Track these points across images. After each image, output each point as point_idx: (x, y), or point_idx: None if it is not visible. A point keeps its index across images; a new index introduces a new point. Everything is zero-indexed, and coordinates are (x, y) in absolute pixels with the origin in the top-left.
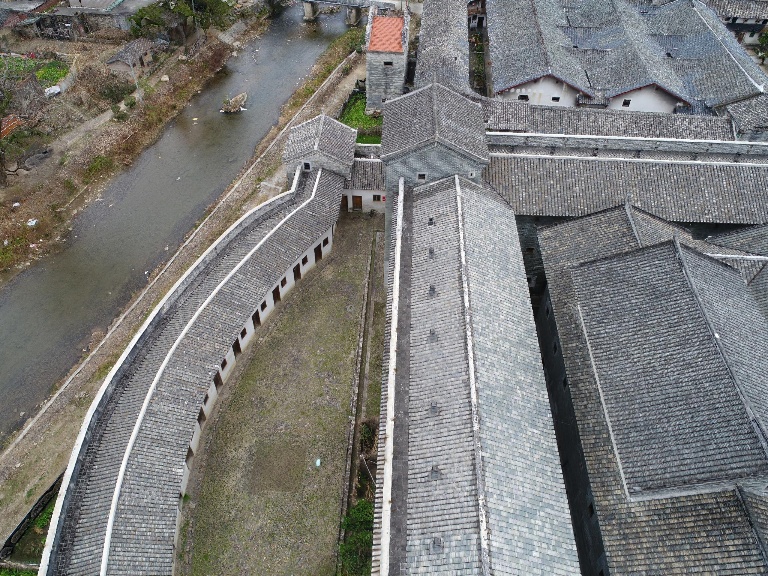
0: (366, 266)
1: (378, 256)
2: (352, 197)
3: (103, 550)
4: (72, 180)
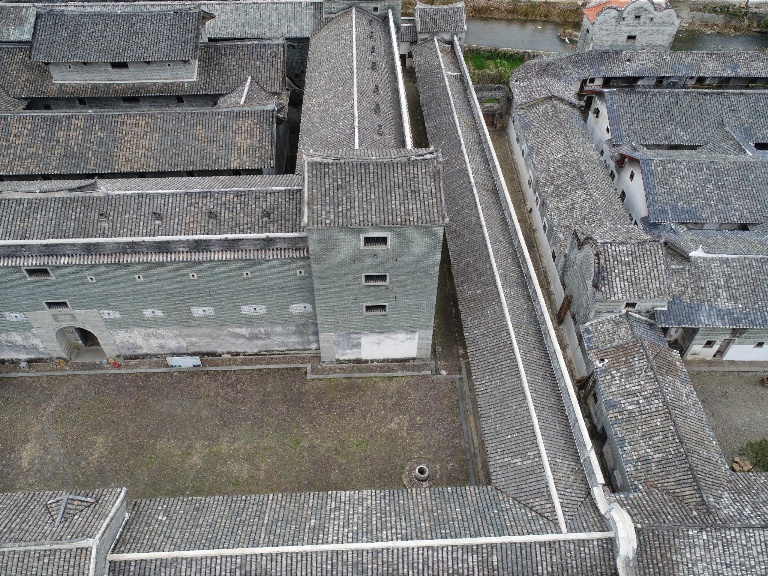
0: None
1: None
2: None
3: None
4: (437, 2)
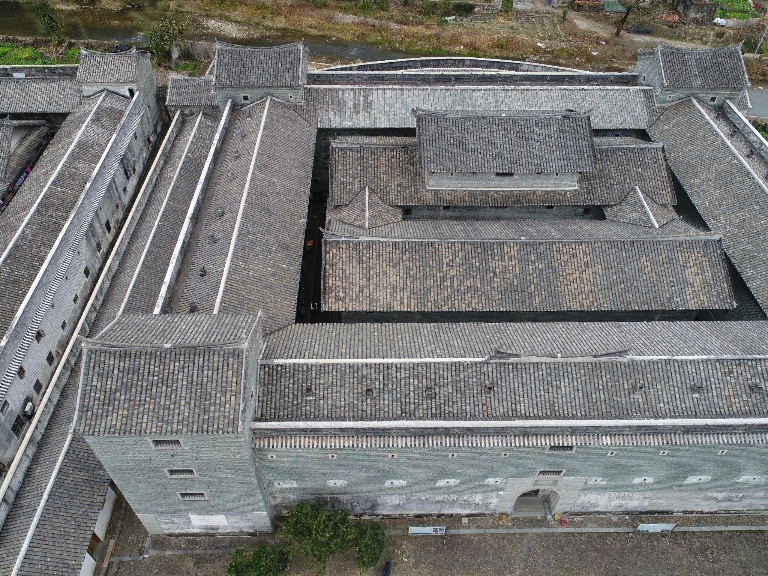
0: None
1: None
2: None
3: None
4: None
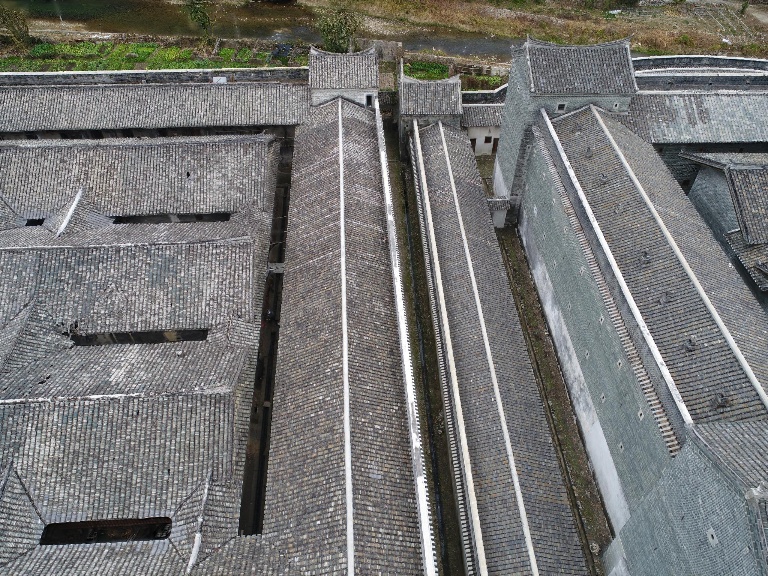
0: None
1: None
2: None
3: None
4: None
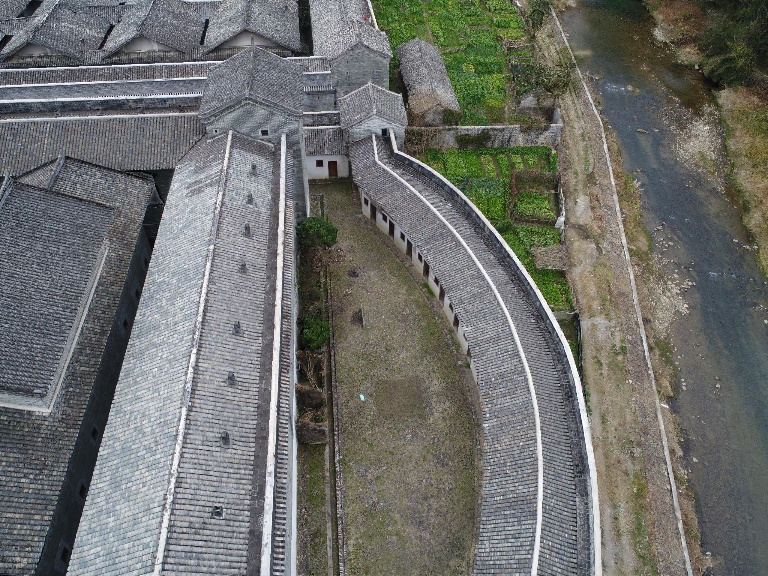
0: None
1: None
2: None
3: None
4: None
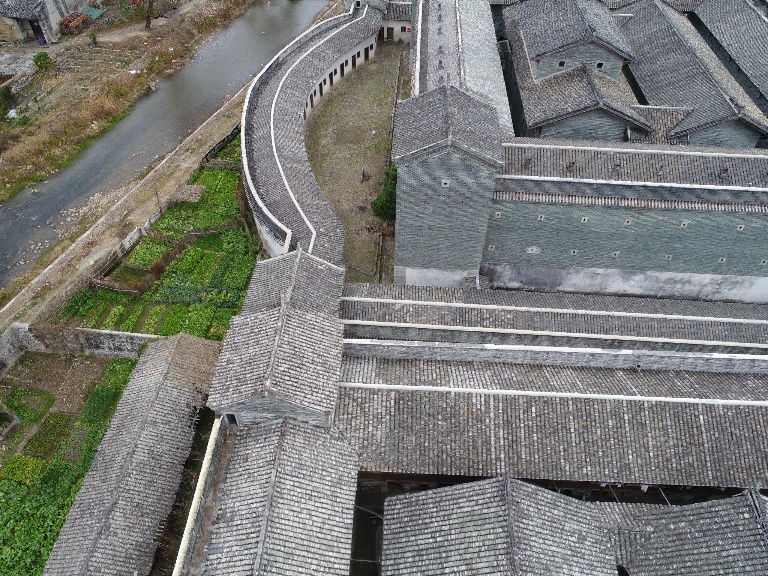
0: (397, 65)
1: (405, 61)
2: (387, 29)
3: (271, 128)
4: (191, 30)
